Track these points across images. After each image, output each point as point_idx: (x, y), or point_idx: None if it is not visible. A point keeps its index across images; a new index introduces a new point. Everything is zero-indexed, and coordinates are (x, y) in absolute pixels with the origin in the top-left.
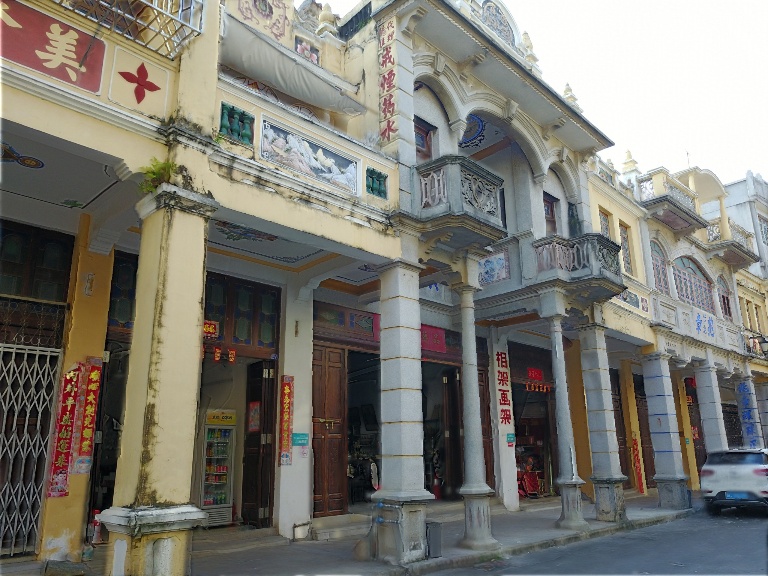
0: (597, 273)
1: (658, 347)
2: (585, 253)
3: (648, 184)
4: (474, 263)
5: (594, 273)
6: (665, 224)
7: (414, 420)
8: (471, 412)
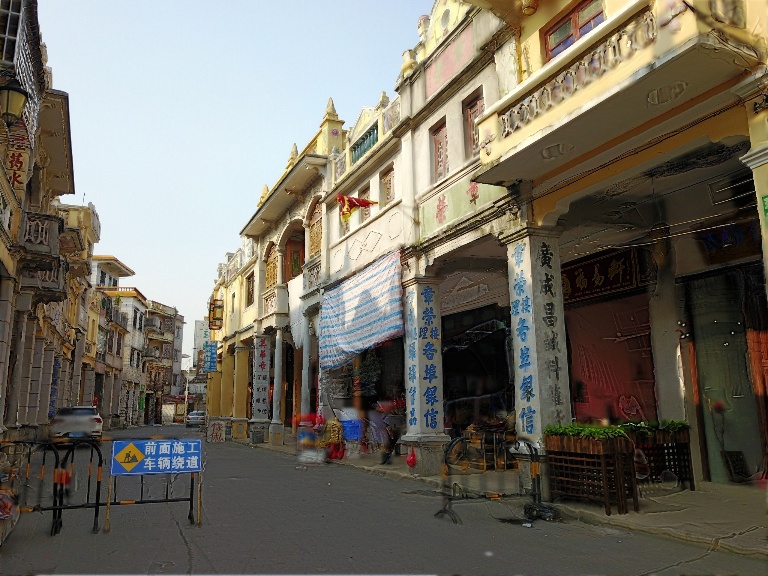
0: (62, 288)
1: (44, 333)
2: (56, 272)
3: (65, 214)
4: (21, 276)
5: (60, 288)
6: (60, 242)
7: (0, 383)
8: (4, 378)
